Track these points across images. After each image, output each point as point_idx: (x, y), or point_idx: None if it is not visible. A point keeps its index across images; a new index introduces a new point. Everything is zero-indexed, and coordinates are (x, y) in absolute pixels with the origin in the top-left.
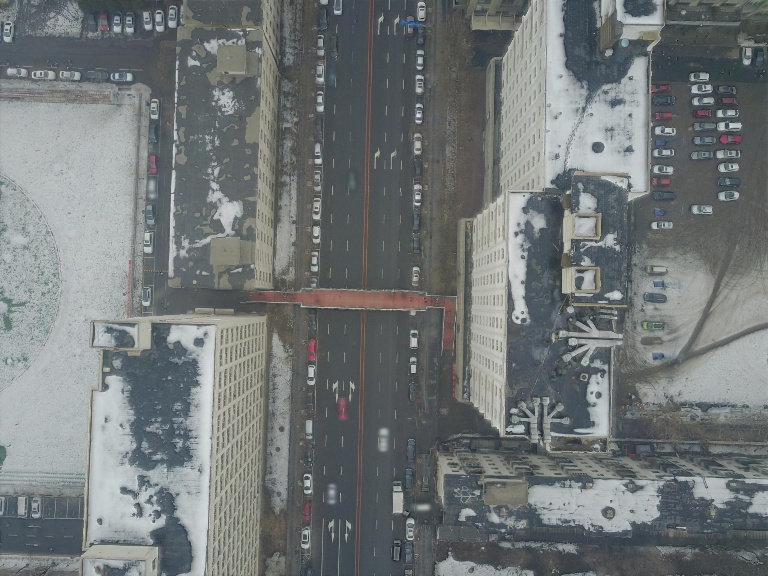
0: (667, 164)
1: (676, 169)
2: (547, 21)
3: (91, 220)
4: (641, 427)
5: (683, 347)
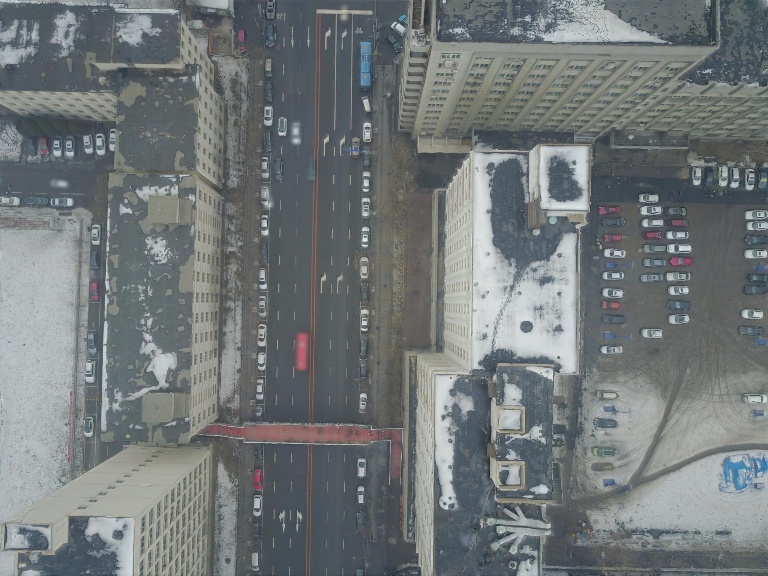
0: (617, 286)
1: (626, 291)
2: (474, 198)
3: (32, 349)
4: (592, 555)
5: (634, 473)
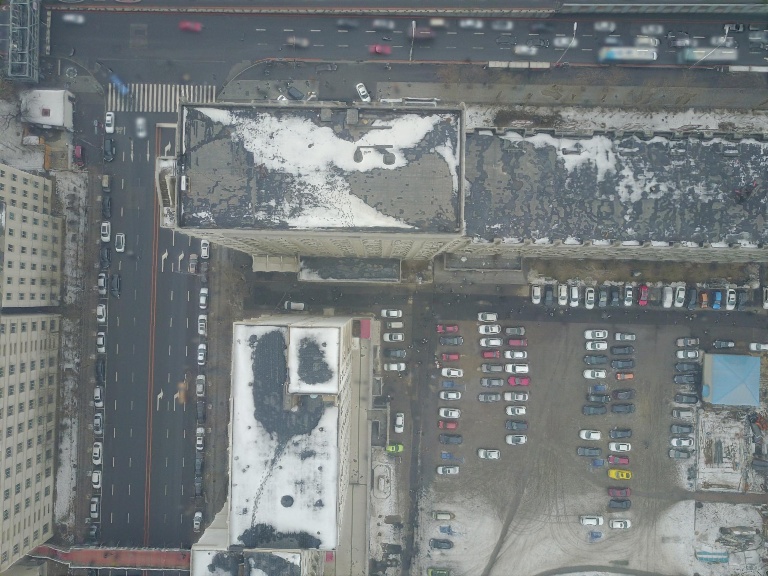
0: (455, 406)
1: (464, 411)
2: (235, 371)
3: None
4: None
5: None
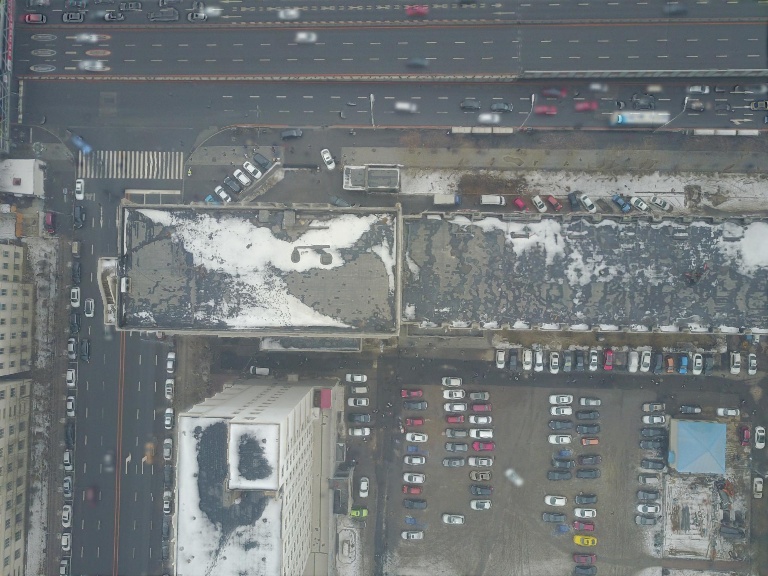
0: (419, 470)
1: (429, 475)
2: (180, 462)
3: None
4: None
5: None
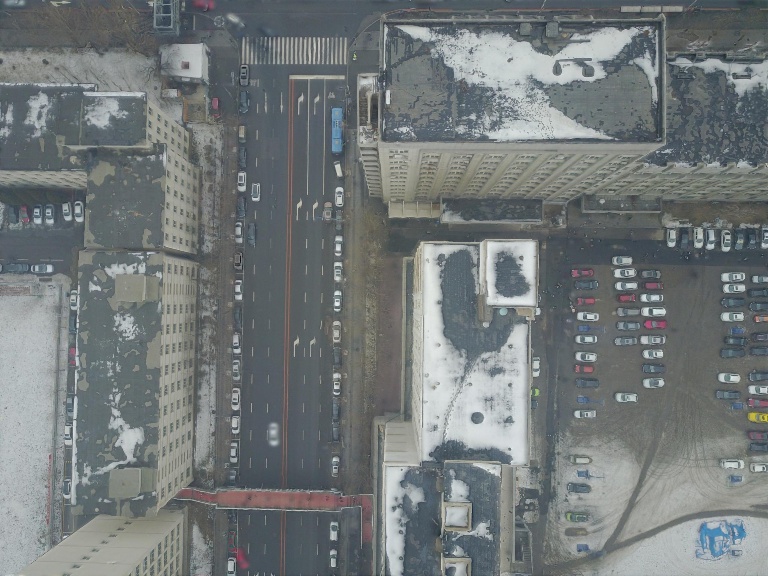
0: (590, 350)
1: (600, 355)
2: (424, 289)
3: (13, 412)
4: None
5: (608, 538)
